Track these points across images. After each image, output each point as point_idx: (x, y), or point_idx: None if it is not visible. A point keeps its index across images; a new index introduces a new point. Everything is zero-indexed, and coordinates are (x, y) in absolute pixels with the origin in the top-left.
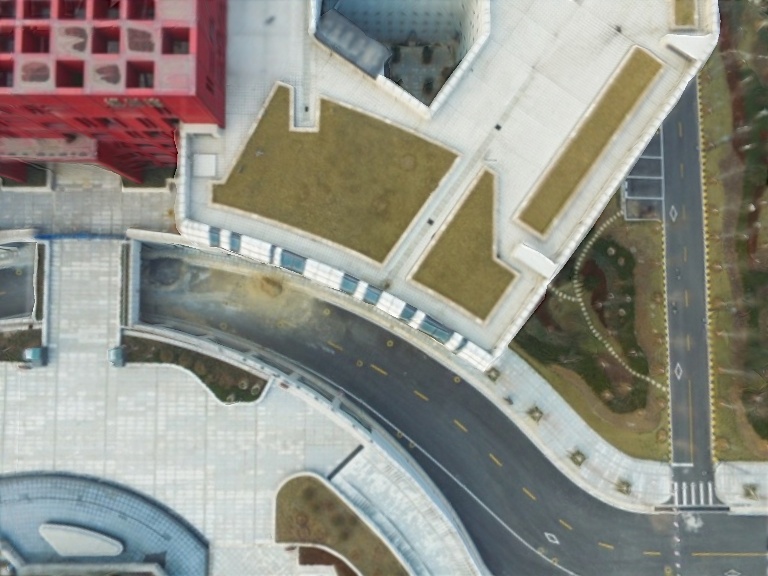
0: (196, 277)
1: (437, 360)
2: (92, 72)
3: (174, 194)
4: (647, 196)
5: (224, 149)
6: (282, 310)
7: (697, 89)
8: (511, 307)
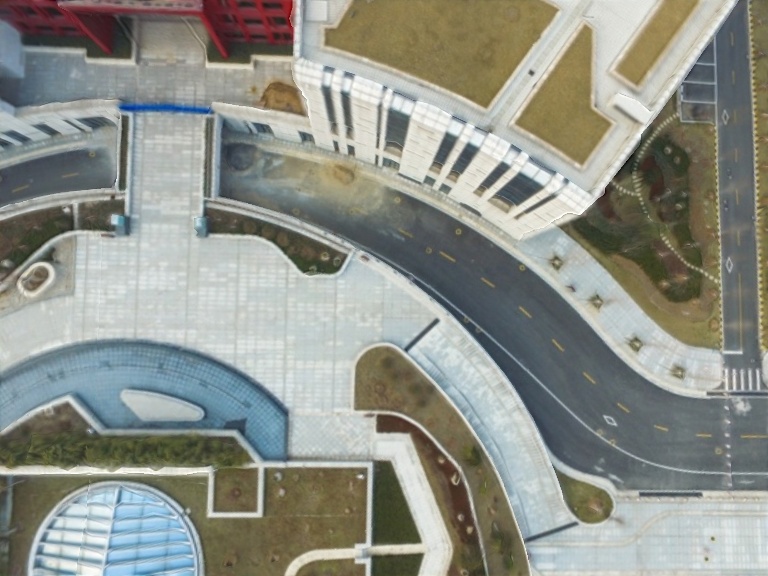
0: (269, 163)
1: (503, 248)
2: None
3: (257, 72)
4: (701, 100)
5: None
6: (354, 197)
7: (748, 2)
8: (607, 154)
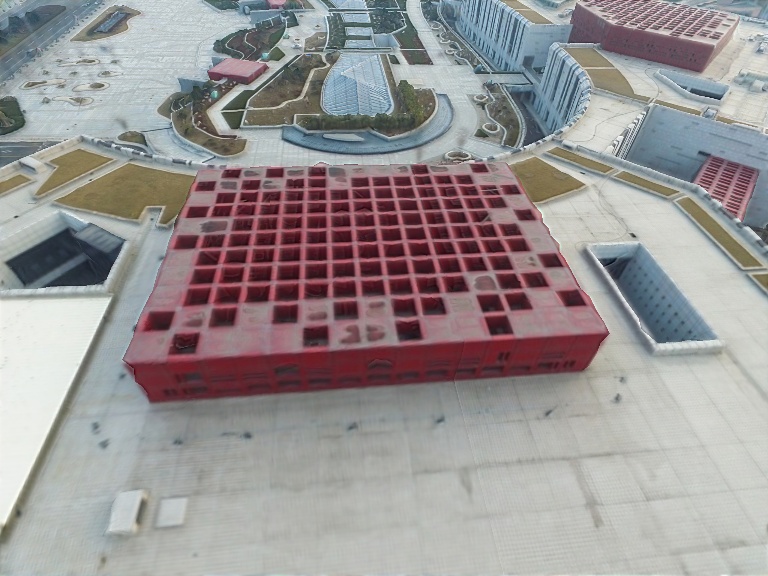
0: None
1: None
2: (261, 174)
3: None
4: None
5: None
6: None
7: None
8: None
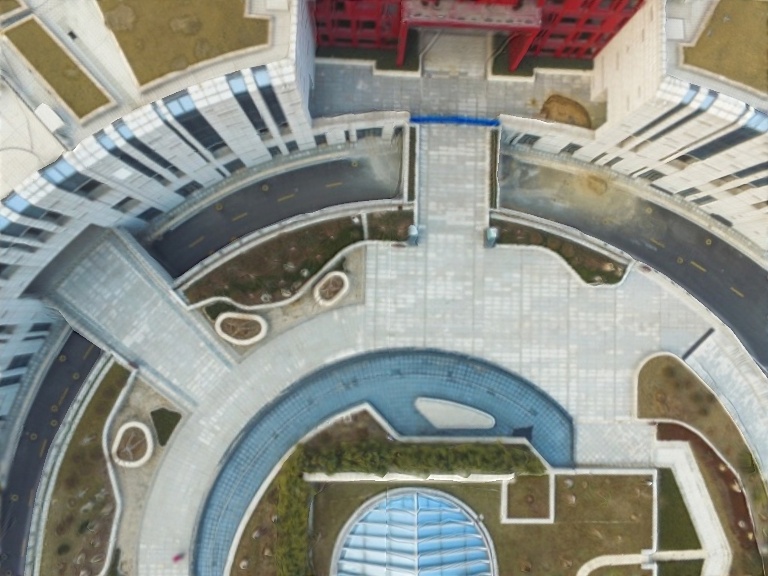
0: (525, 174)
1: (752, 259)
2: None
3: (537, 84)
4: None
5: (690, 15)
6: (607, 208)
7: None
8: None
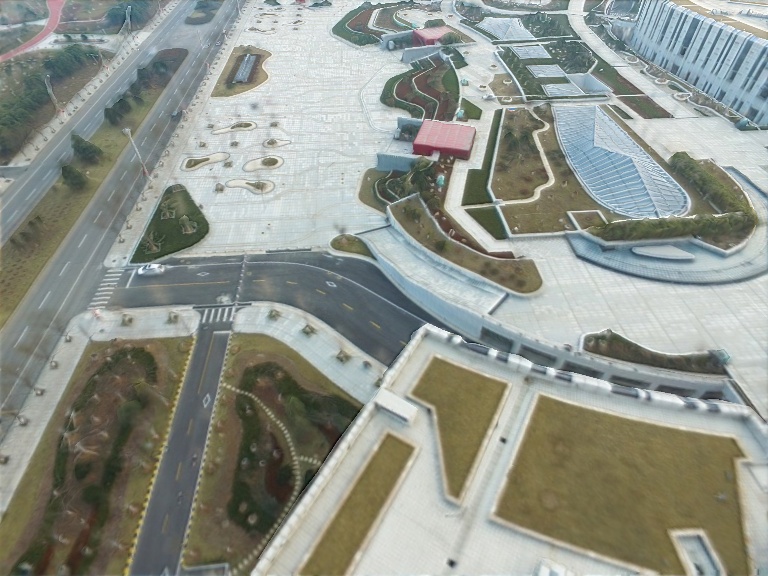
0: None
1: None
2: None
3: None
4: None
5: (761, 500)
6: None
7: None
8: (411, 369)
